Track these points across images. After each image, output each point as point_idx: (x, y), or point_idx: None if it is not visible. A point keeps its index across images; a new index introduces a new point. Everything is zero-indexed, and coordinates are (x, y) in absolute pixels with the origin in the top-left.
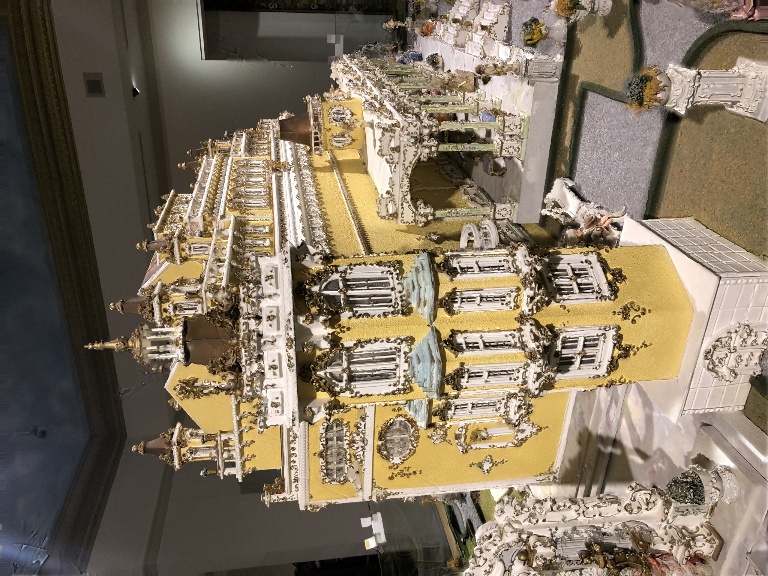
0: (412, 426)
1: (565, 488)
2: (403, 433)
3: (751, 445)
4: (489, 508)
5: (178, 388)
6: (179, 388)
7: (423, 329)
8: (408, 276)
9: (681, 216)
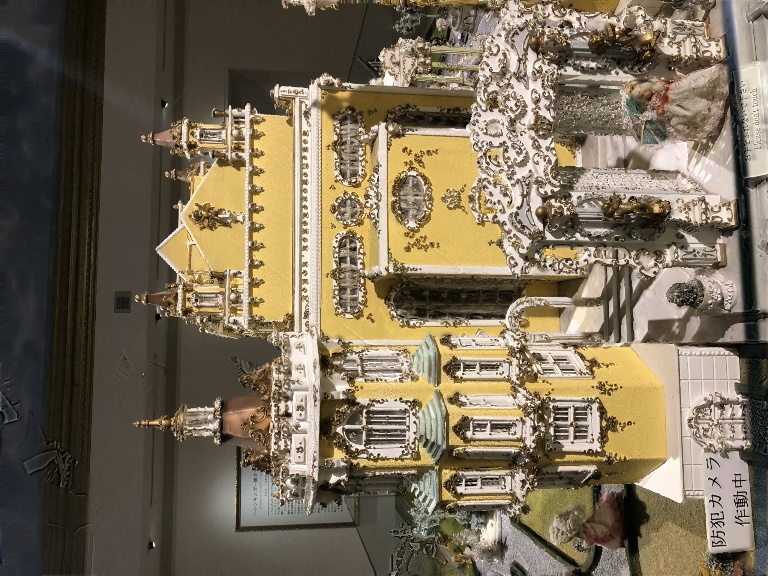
0: (425, 183)
1: (594, 270)
2: (416, 192)
3: None
4: (533, 506)
5: (194, 210)
6: (195, 210)
7: None
8: None
9: None
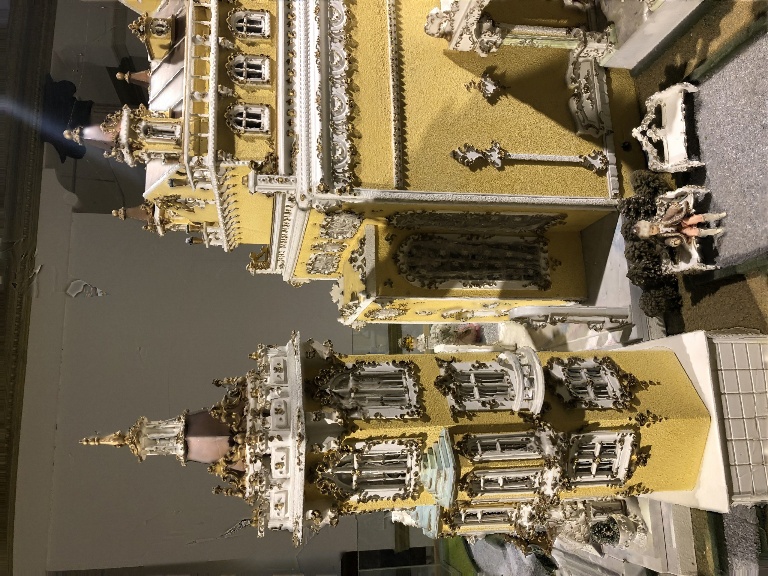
0: None
1: (527, 336)
2: None
3: (673, 531)
4: None
5: (159, 204)
6: (160, 204)
7: (429, 505)
8: (428, 465)
9: (765, 319)
